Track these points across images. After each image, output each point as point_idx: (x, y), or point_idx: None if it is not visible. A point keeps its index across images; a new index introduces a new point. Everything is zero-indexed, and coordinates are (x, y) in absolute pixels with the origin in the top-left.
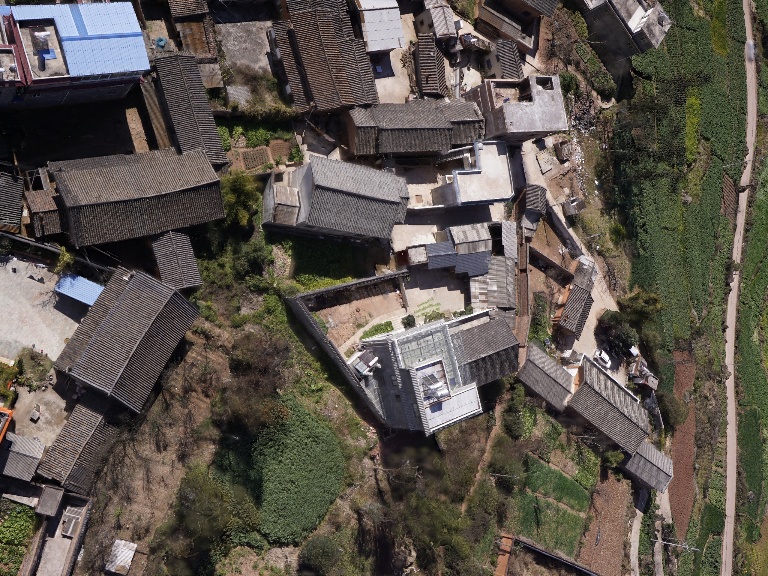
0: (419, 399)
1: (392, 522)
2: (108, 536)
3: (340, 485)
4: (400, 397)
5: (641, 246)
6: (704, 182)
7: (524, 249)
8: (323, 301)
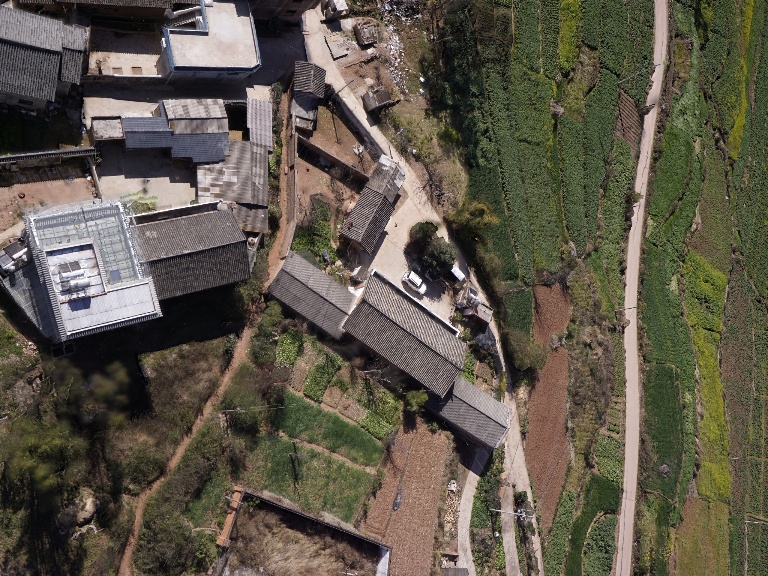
0: (51, 292)
1: None
2: None
3: None
4: None
5: (483, 156)
6: (590, 97)
7: (293, 141)
8: None
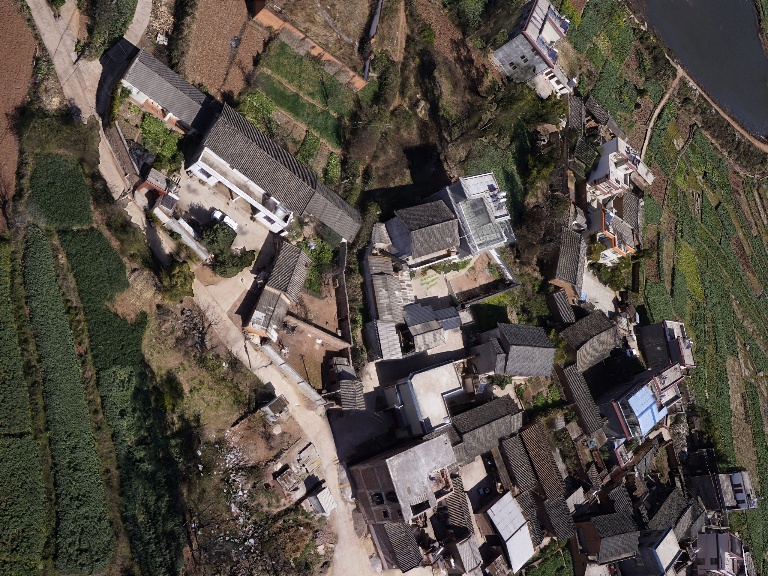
0: None
1: None
2: None
3: None
4: None
5: None
6: None
7: None
8: (494, 287)
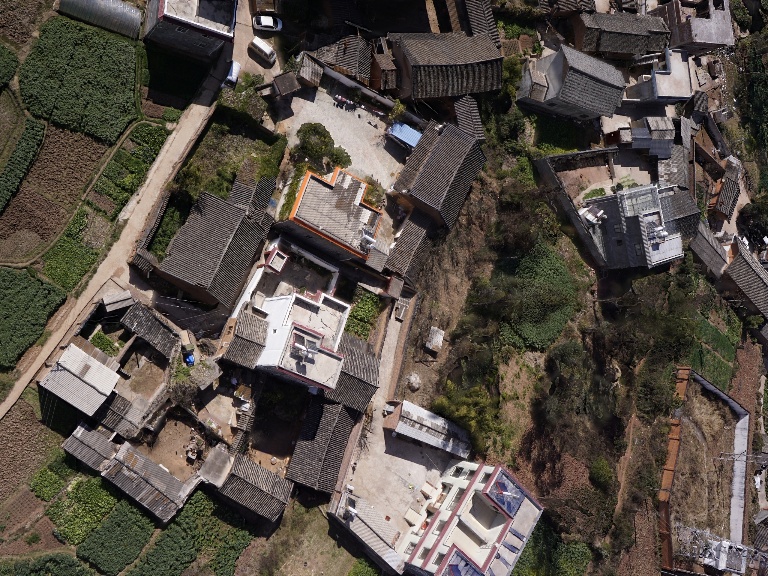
0: (645, 239)
1: (609, 342)
2: (425, 323)
3: (571, 310)
4: (622, 241)
5: (767, 157)
6: None
7: (691, 144)
8: (558, 166)
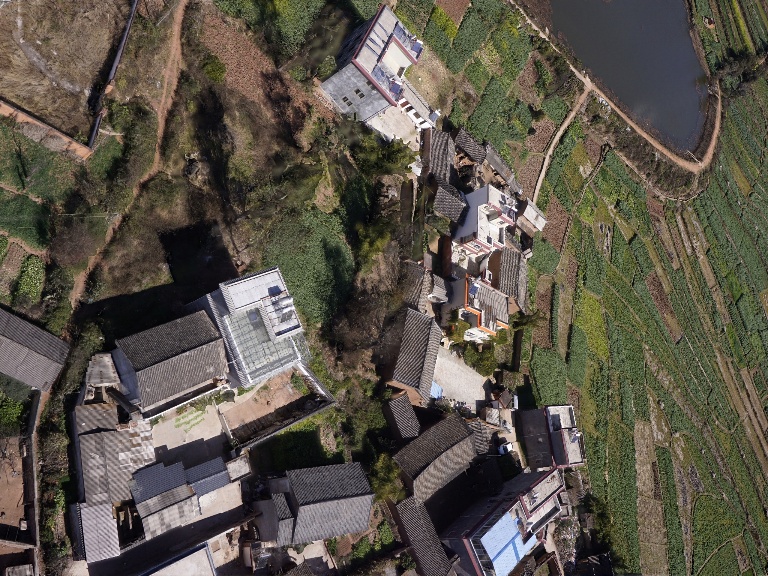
0: None
1: None
2: None
3: None
4: None
5: None
6: None
7: None
8: (299, 407)
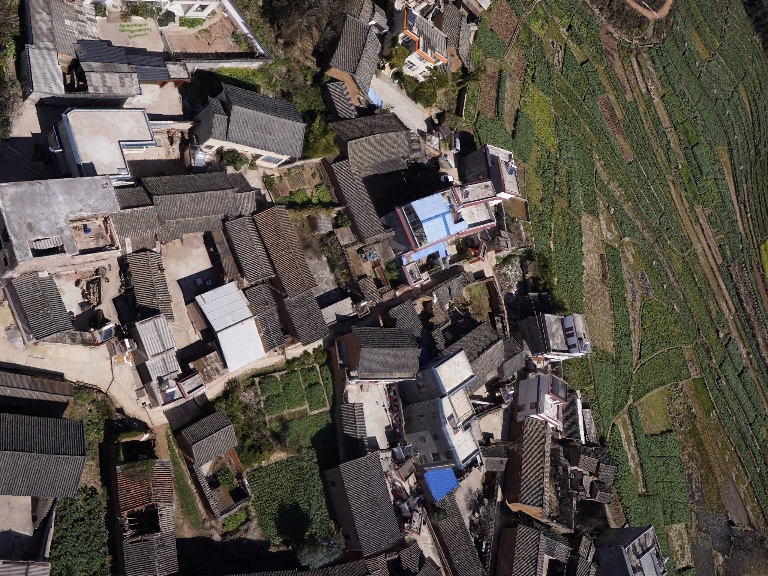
0: None
1: None
2: None
3: None
4: None
5: None
6: None
7: None
8: None
